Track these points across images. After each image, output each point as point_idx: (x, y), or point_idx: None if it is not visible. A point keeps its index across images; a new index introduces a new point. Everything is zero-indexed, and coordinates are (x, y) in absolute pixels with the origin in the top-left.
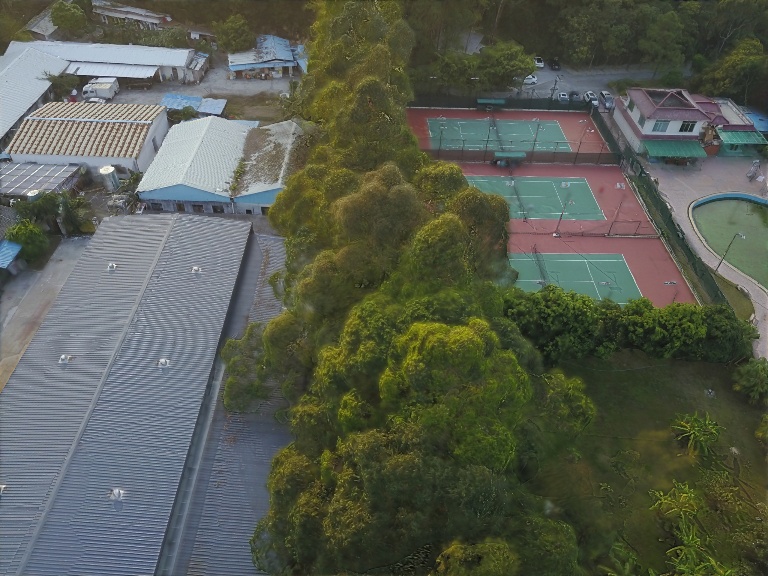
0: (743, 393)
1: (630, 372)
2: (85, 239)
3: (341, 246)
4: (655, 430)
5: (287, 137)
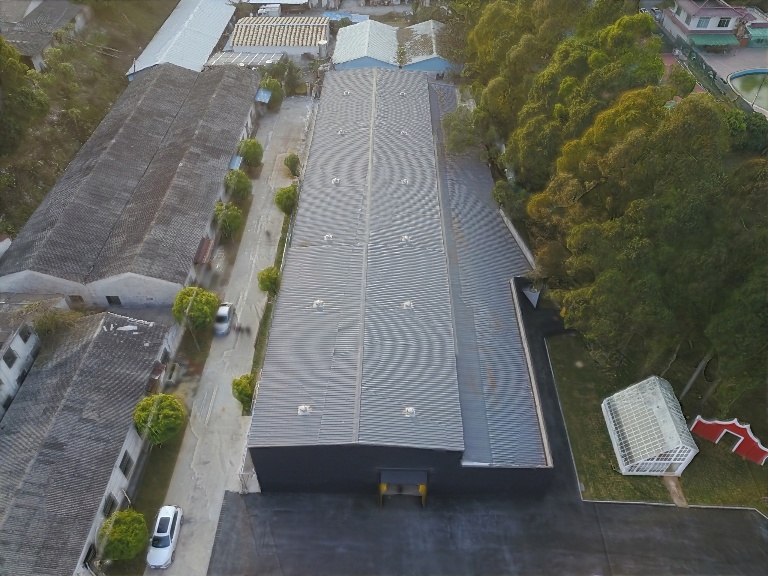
0: None
1: None
2: (299, 98)
3: (539, 26)
4: None
5: (429, 30)
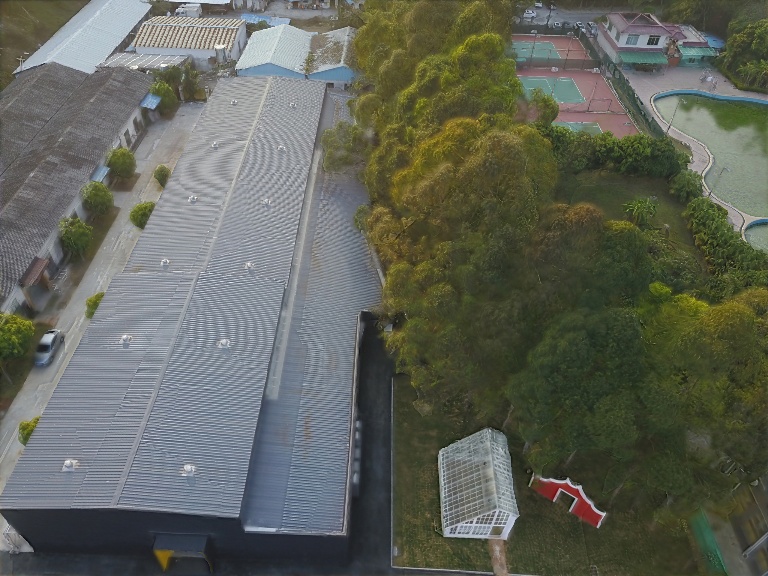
0: (676, 194)
1: (598, 186)
2: (198, 104)
3: None
4: (613, 215)
5: (343, 38)
